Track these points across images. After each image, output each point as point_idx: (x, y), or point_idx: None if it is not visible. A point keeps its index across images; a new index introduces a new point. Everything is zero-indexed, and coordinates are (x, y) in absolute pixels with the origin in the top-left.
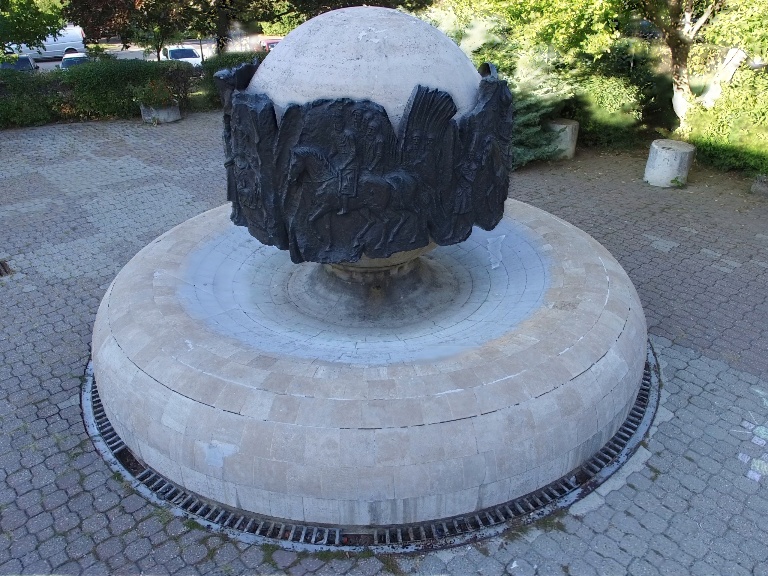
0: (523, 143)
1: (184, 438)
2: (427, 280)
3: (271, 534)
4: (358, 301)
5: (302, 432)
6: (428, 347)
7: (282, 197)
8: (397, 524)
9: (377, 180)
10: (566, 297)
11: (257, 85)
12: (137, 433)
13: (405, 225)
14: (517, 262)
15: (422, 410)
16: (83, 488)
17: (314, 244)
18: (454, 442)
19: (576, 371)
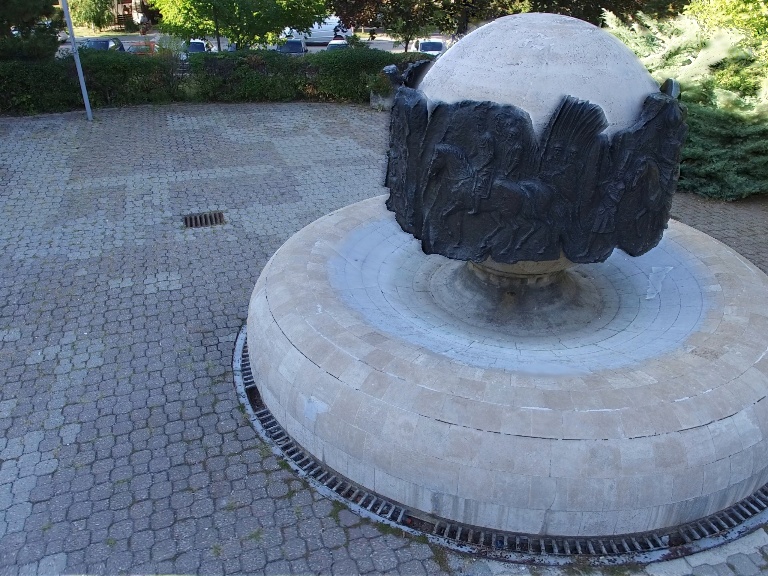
0: (749, 172)
1: (292, 388)
2: (569, 297)
3: (345, 494)
4: (490, 303)
5: (385, 409)
6: (539, 361)
7: (423, 189)
8: (458, 521)
9: (511, 185)
10: (711, 344)
11: (425, 82)
12: (261, 375)
13: (535, 235)
14: (675, 297)
15: (502, 418)
16: (214, 410)
17: (444, 238)
18: (527, 458)
19: (688, 423)
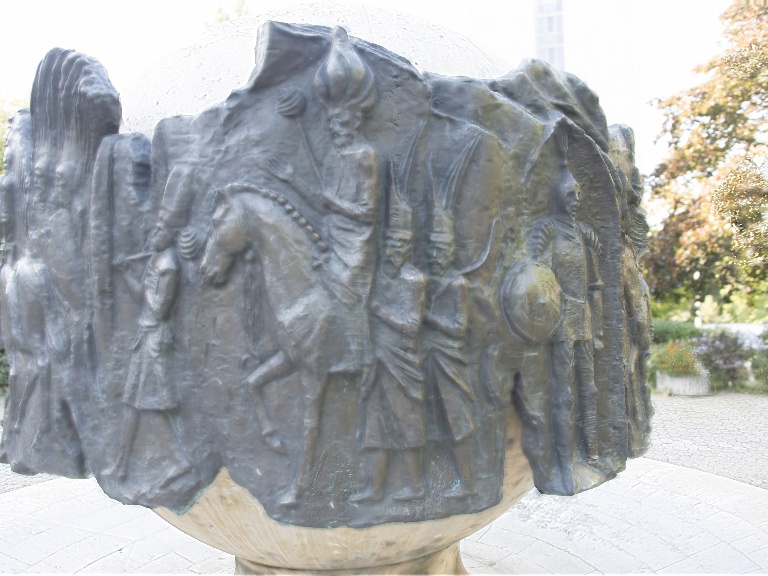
0: None
1: None
2: None
3: None
4: None
5: None
6: None
7: None
8: None
9: None
10: None
11: None
12: None
13: None
14: None
15: None
16: None
17: None
18: None
19: None
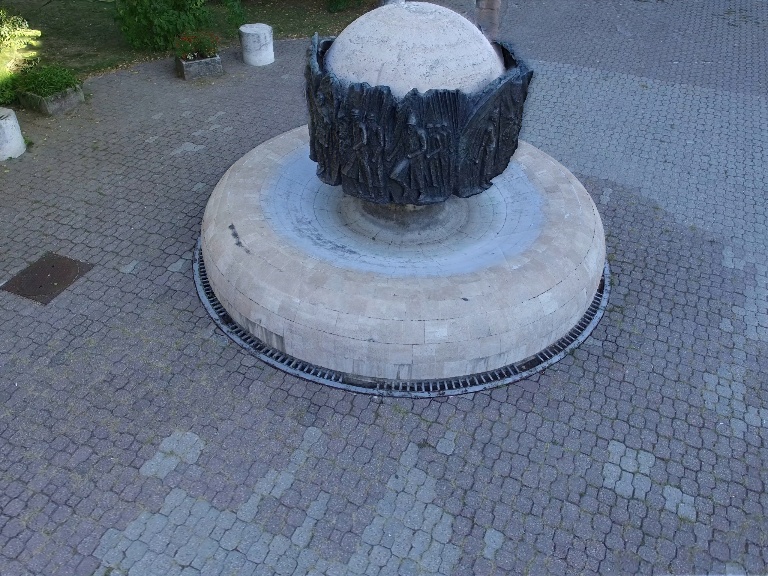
0: None
1: None
2: None
3: None
4: None
5: None
6: None
7: None
8: None
9: None
10: None
11: None
12: None
13: None
14: None
15: None
16: (630, 291)
17: None
18: None
19: None
